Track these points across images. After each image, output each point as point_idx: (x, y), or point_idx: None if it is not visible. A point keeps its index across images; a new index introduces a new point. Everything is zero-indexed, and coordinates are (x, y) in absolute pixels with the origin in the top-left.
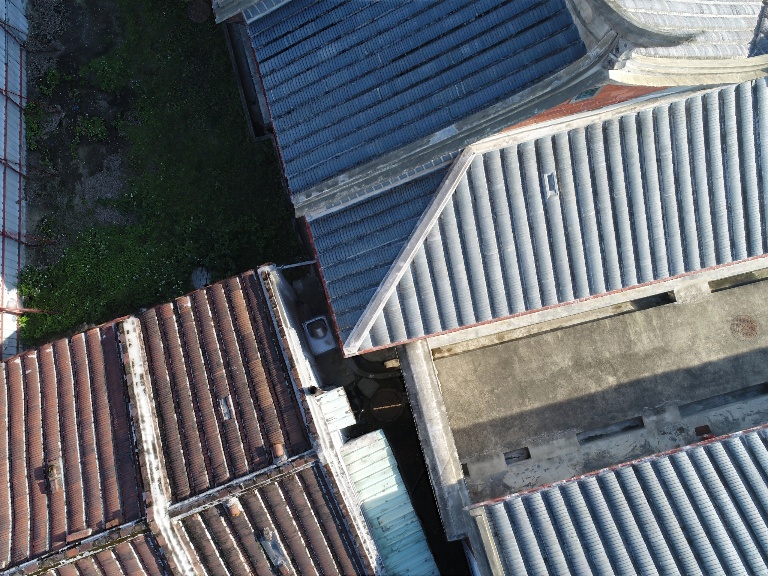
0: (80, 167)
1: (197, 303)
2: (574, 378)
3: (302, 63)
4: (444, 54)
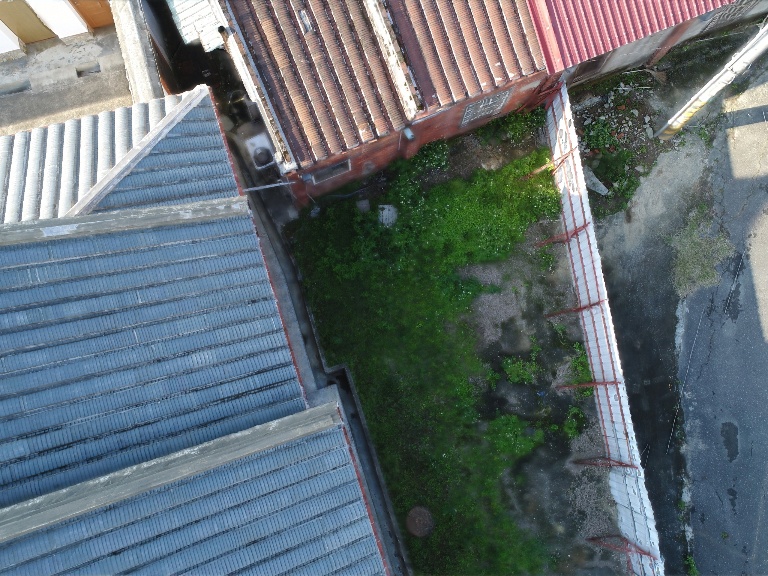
0: (525, 327)
1: (352, 132)
2: None
3: (236, 351)
4: (53, 324)
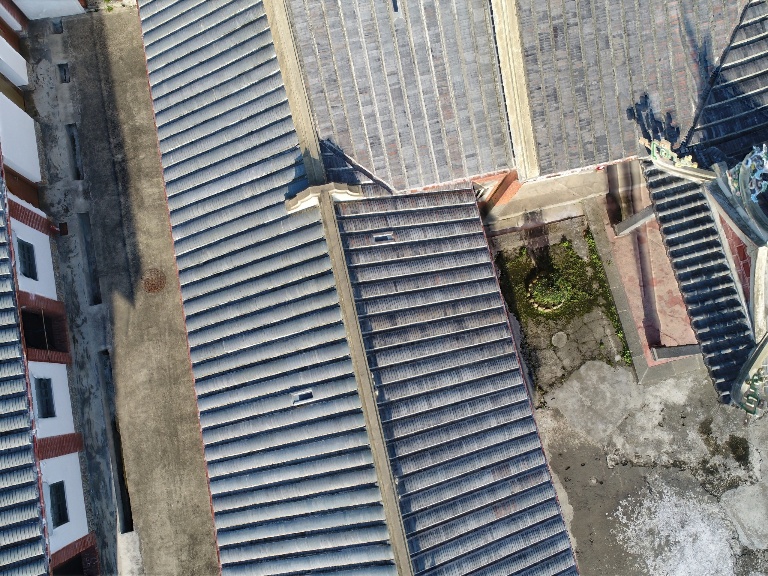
0: None
1: None
2: (124, 126)
3: None
4: None
